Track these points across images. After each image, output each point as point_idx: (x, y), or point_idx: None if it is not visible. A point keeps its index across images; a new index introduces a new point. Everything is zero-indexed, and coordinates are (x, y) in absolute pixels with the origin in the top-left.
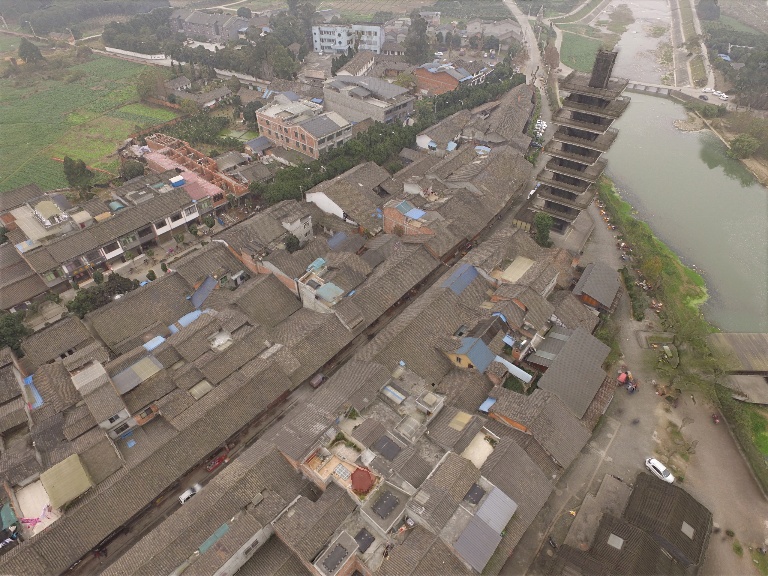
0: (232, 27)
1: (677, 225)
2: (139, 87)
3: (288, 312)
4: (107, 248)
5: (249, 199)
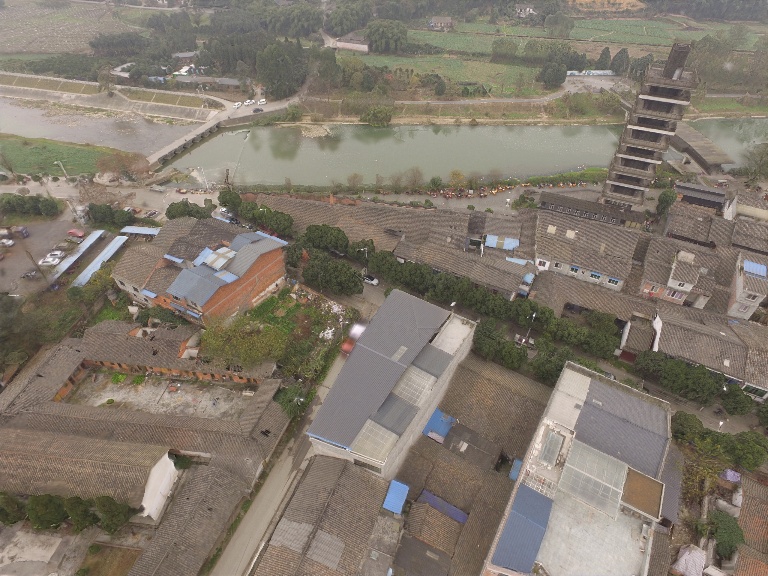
0: None
1: (523, 166)
2: None
3: None
4: None
5: None
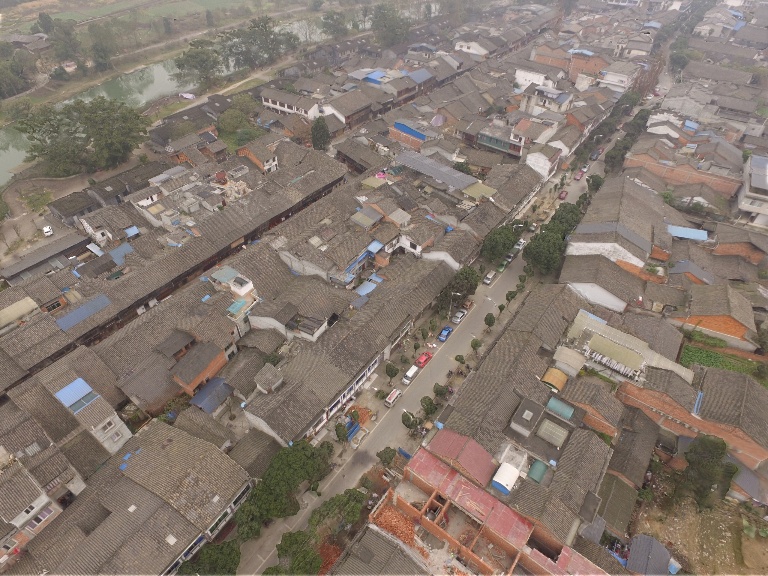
0: None
1: None
2: None
3: None
4: None
5: None
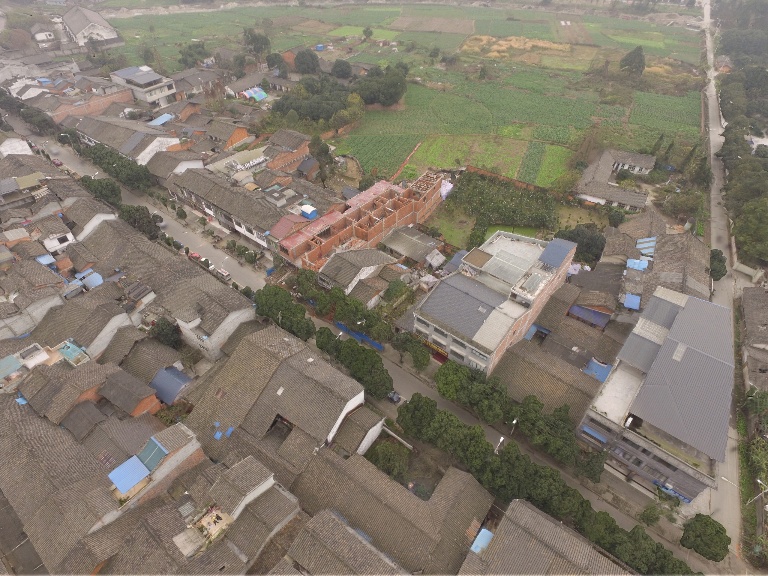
0: None
1: None
2: None
3: None
4: None
5: None
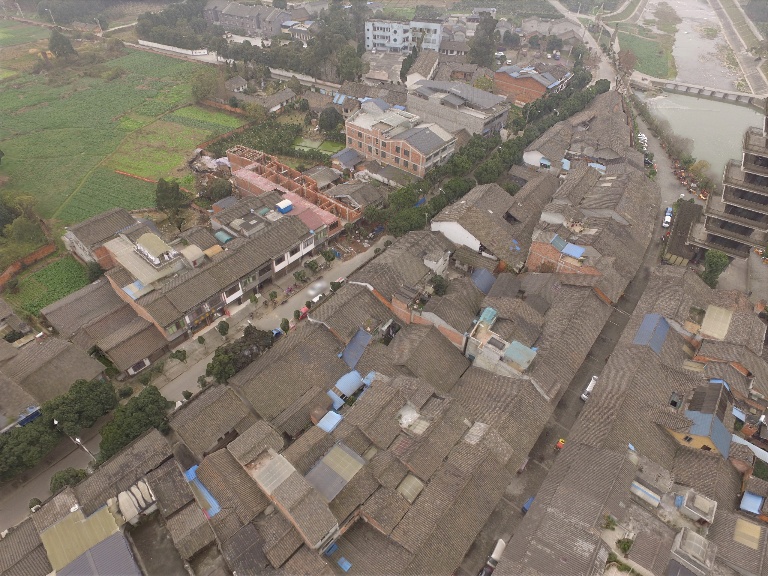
0: (276, 20)
1: None
2: (196, 88)
3: (458, 372)
4: (228, 291)
5: (358, 225)
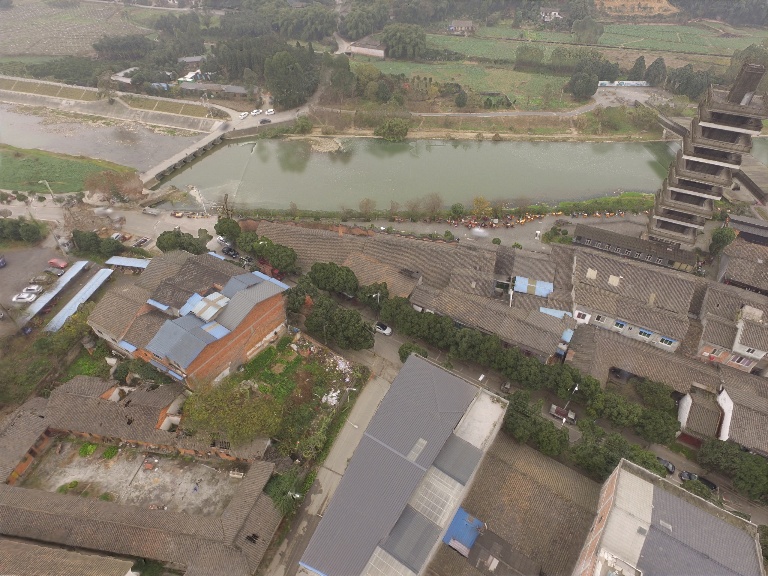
0: None
1: (552, 188)
2: None
3: None
4: None
5: None
